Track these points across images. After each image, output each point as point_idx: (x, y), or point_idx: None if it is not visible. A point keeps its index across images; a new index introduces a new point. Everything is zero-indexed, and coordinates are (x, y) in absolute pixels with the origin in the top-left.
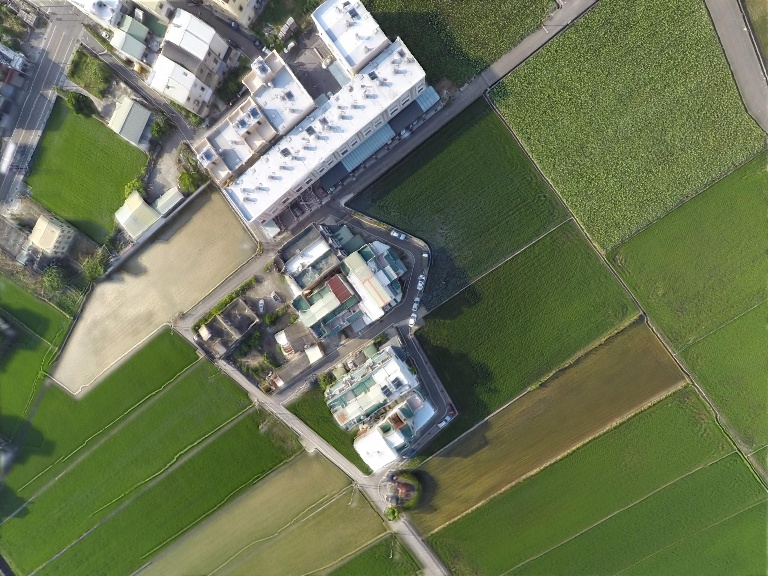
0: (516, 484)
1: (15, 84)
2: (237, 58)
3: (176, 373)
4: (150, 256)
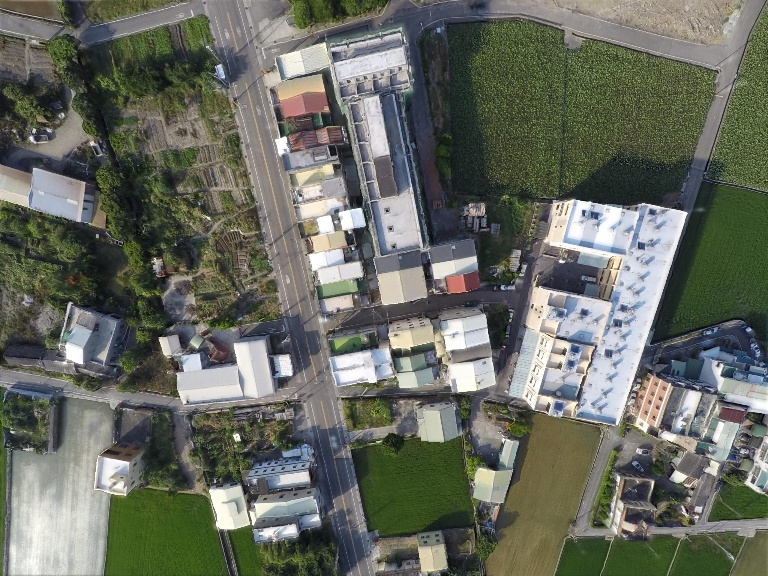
0: None
1: (314, 470)
2: None
3: (602, 567)
4: (514, 502)
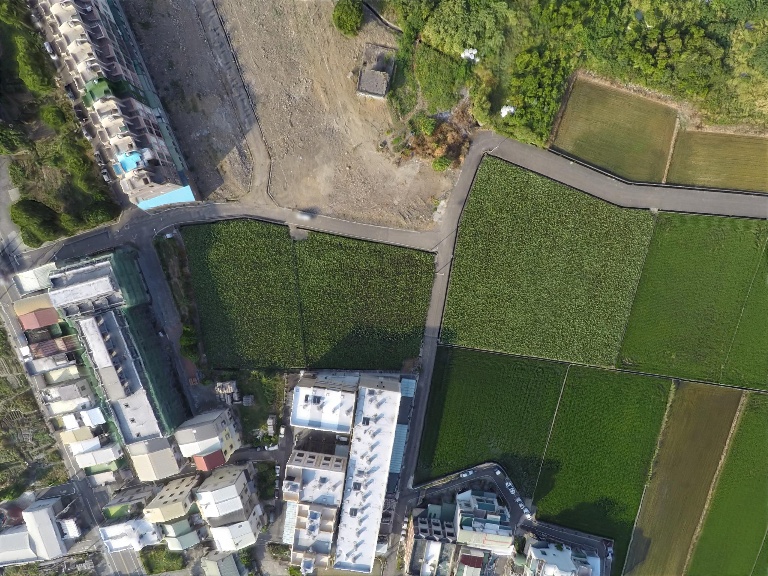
0: (694, 545)
1: None
2: (252, 467)
3: None
4: None
